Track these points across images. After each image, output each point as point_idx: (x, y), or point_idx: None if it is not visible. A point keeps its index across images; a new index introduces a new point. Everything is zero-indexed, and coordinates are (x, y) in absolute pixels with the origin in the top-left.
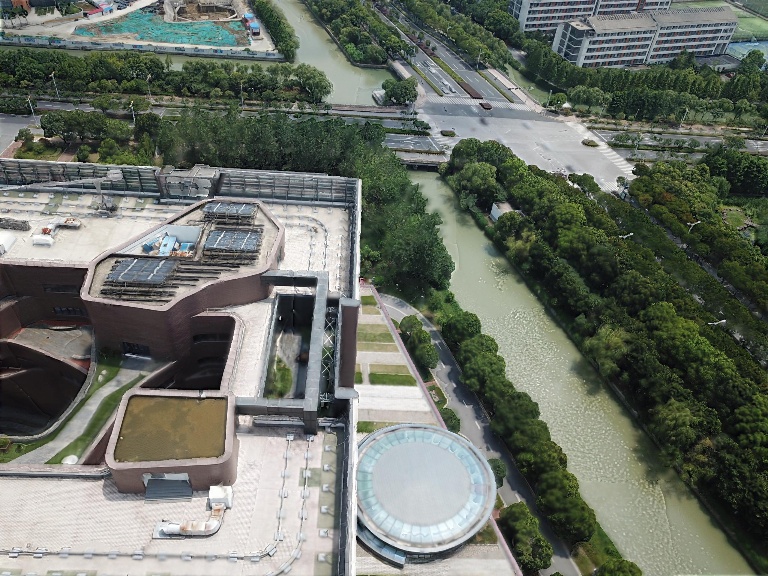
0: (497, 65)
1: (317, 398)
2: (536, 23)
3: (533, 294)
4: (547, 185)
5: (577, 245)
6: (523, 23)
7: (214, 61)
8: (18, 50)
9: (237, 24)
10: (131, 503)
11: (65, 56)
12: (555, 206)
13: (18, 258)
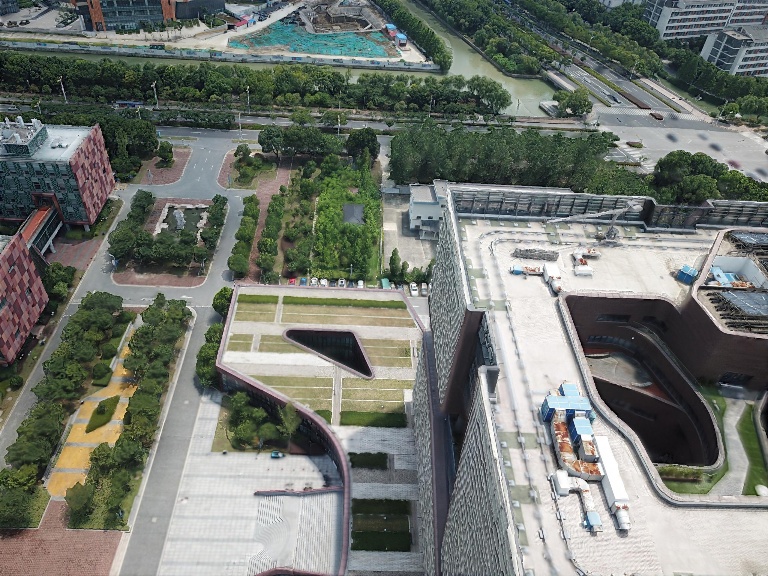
0: (649, 74)
1: None
2: (674, 32)
3: None
4: None
5: None
6: (662, 32)
7: (390, 74)
8: (201, 64)
9: (379, 35)
10: None
11: (248, 70)
12: None
13: (591, 290)
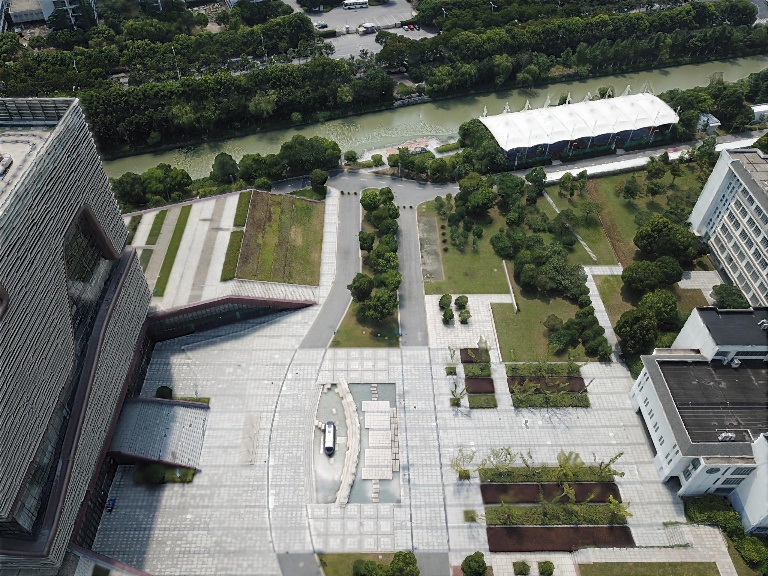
0: None
1: None
2: None
3: None
4: None
5: None
6: None
7: None
8: None
9: None
10: None
11: None
12: None
13: None
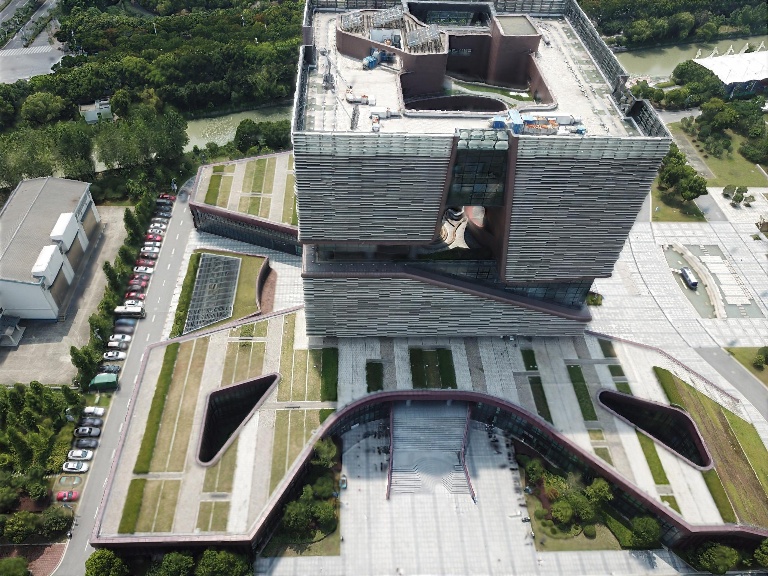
0: None
1: (487, 2)
2: None
3: (190, 121)
4: (93, 66)
5: (170, 72)
6: None
7: None
8: None
9: None
10: (541, 52)
11: None
12: (123, 68)
13: None
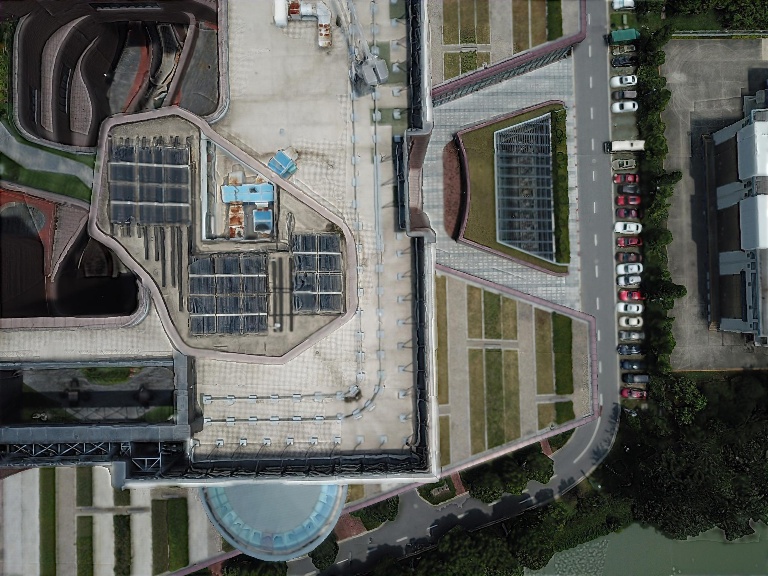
0: None
1: None
2: None
3: None
4: None
5: None
6: None
7: None
8: None
9: None
10: None
11: None
12: None
13: None
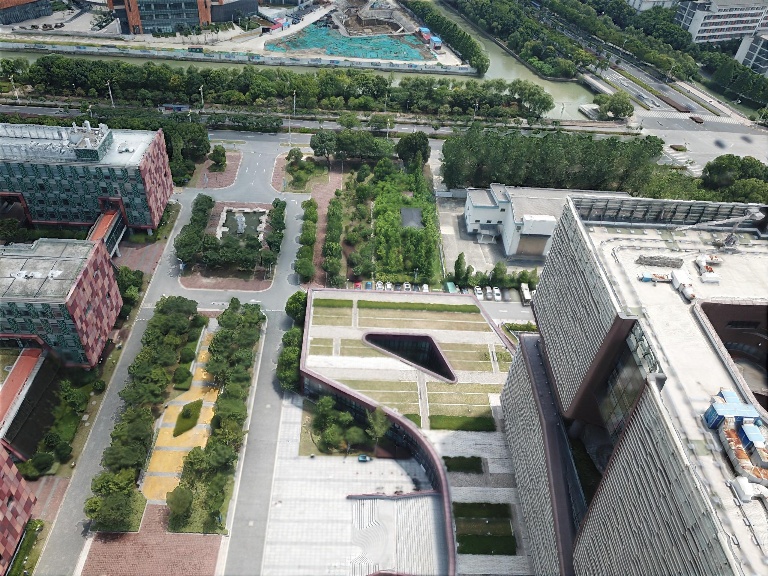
0: (684, 78)
1: None
2: (706, 35)
3: None
4: None
5: None
6: (694, 35)
7: (432, 77)
8: (244, 68)
9: (412, 38)
10: None
11: (292, 74)
12: None
13: (725, 297)
